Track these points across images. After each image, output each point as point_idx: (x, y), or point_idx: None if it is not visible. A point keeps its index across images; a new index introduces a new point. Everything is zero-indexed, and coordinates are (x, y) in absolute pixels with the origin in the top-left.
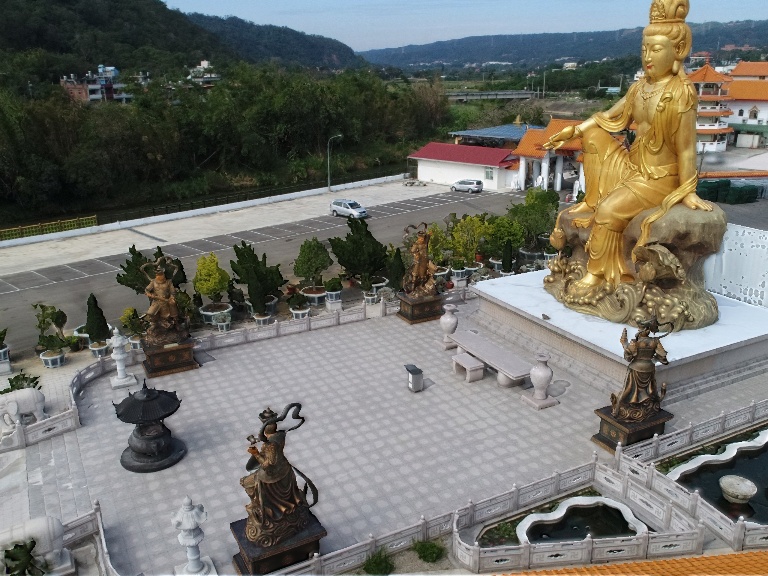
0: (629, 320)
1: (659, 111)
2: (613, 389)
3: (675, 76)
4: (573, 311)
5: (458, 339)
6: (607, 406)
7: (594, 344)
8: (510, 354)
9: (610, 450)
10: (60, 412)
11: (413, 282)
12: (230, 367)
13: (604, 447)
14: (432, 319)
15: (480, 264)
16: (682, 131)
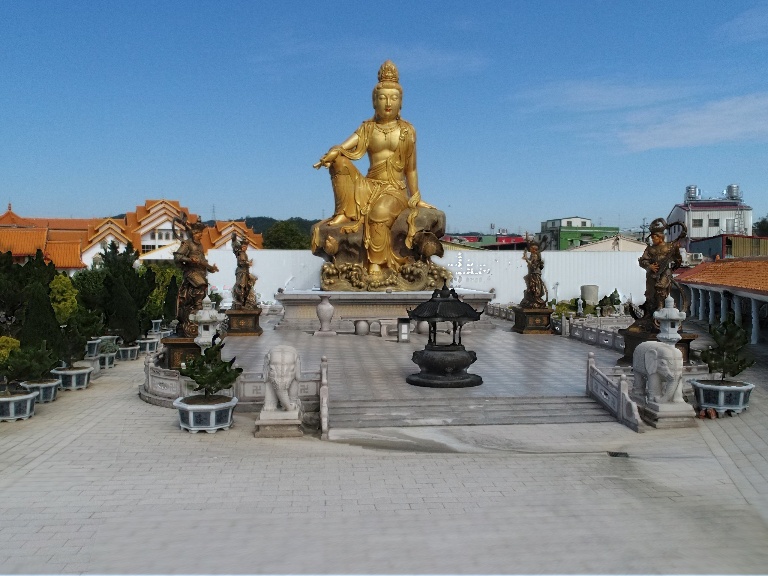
0: (426, 287)
1: (403, 140)
2: None
3: (399, 120)
4: None
5: (358, 316)
6: None
7: None
8: None
9: (542, 332)
10: (234, 415)
11: (242, 294)
12: (250, 364)
13: (536, 332)
14: (261, 332)
15: (163, 317)
16: (414, 156)
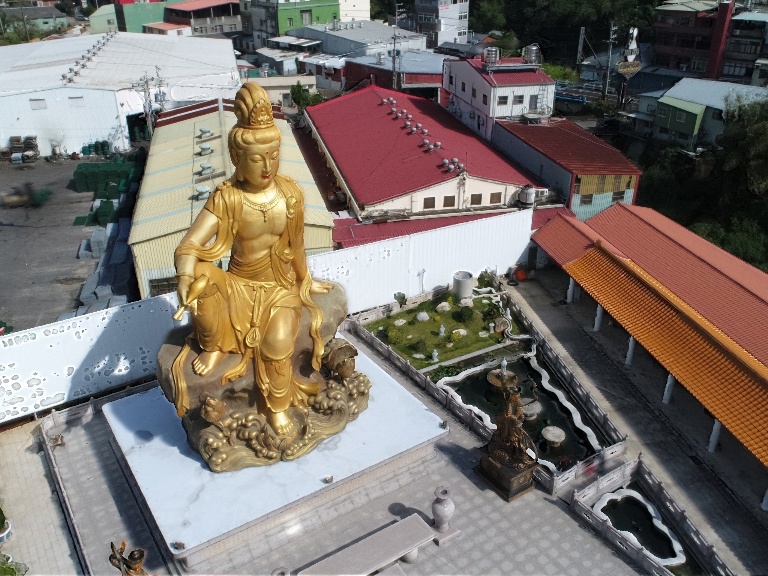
0: None
1: None
2: (418, 471)
3: (276, 177)
4: (305, 457)
5: None
6: (502, 470)
7: (400, 453)
8: (378, 534)
9: None
10: None
11: None
12: None
13: (522, 495)
14: None
15: None
16: None
